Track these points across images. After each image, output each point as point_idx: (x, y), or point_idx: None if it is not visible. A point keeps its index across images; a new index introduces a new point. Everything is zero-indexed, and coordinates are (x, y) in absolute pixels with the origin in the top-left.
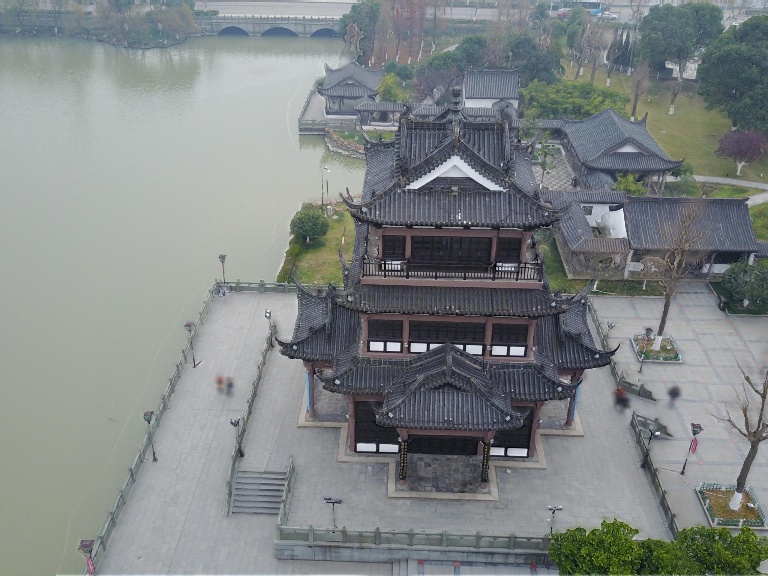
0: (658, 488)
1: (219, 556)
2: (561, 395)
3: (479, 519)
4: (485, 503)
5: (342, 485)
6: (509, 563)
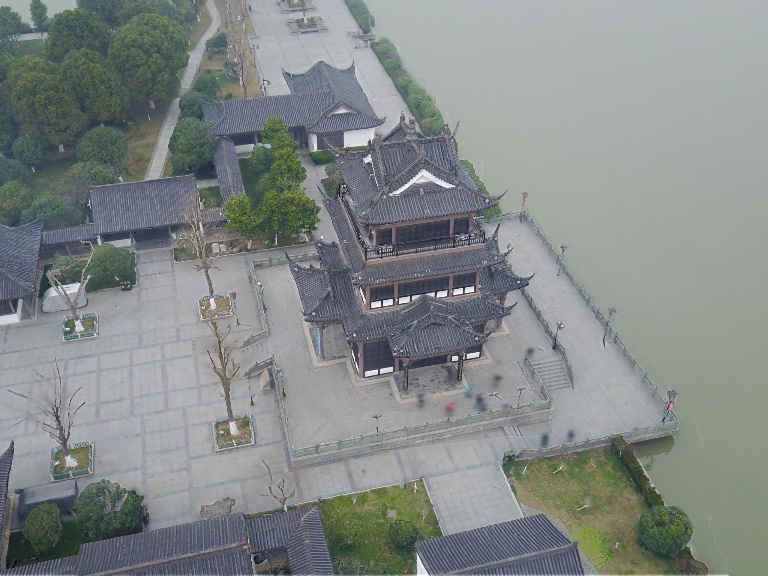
0: None
1: None
2: None
3: None
4: None
5: None
6: None
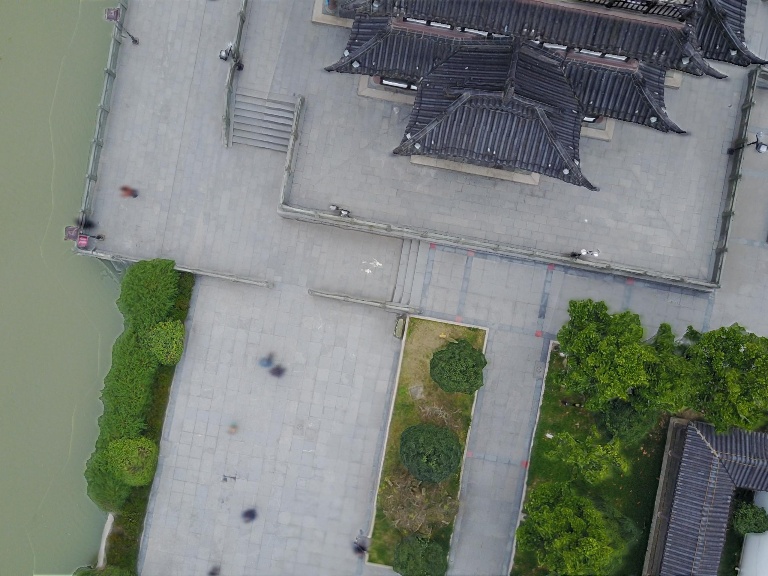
0: (730, 197)
1: (220, 204)
2: (652, 126)
3: (508, 209)
4: (521, 186)
5: (359, 135)
6: (526, 261)
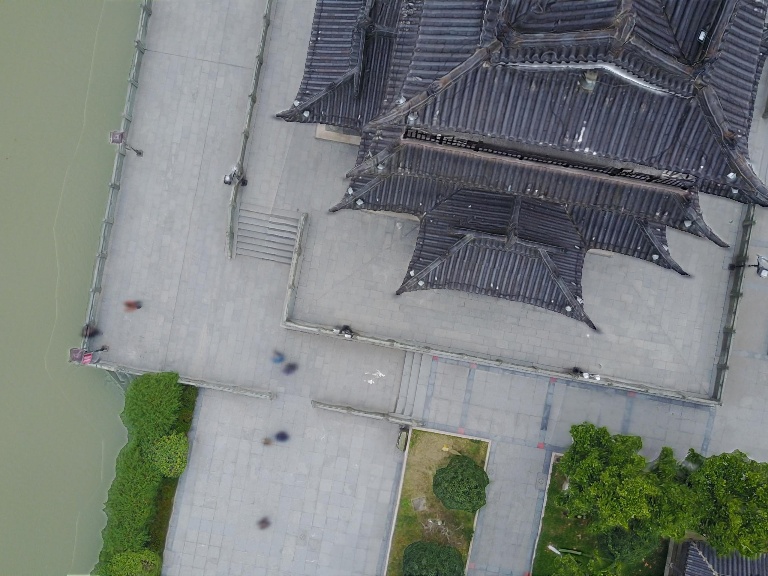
0: (731, 314)
1: (223, 315)
2: (654, 262)
3: (510, 324)
4: None
5: (362, 250)
6: (529, 373)
